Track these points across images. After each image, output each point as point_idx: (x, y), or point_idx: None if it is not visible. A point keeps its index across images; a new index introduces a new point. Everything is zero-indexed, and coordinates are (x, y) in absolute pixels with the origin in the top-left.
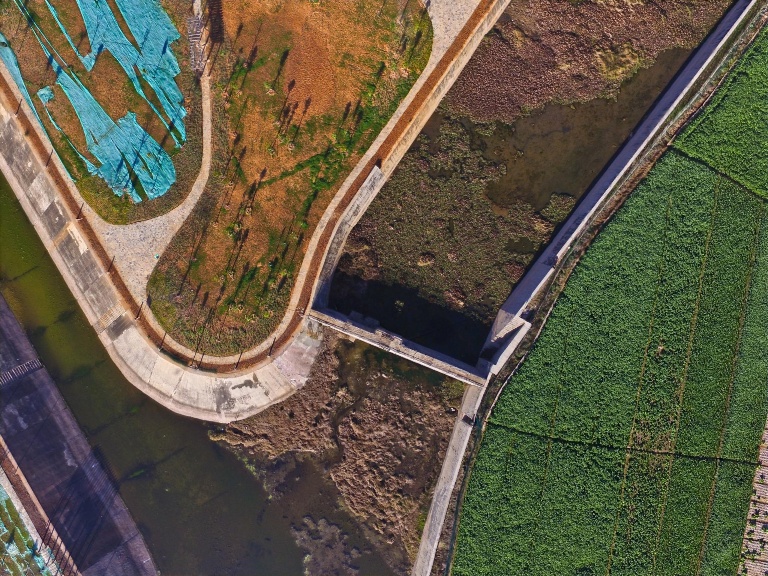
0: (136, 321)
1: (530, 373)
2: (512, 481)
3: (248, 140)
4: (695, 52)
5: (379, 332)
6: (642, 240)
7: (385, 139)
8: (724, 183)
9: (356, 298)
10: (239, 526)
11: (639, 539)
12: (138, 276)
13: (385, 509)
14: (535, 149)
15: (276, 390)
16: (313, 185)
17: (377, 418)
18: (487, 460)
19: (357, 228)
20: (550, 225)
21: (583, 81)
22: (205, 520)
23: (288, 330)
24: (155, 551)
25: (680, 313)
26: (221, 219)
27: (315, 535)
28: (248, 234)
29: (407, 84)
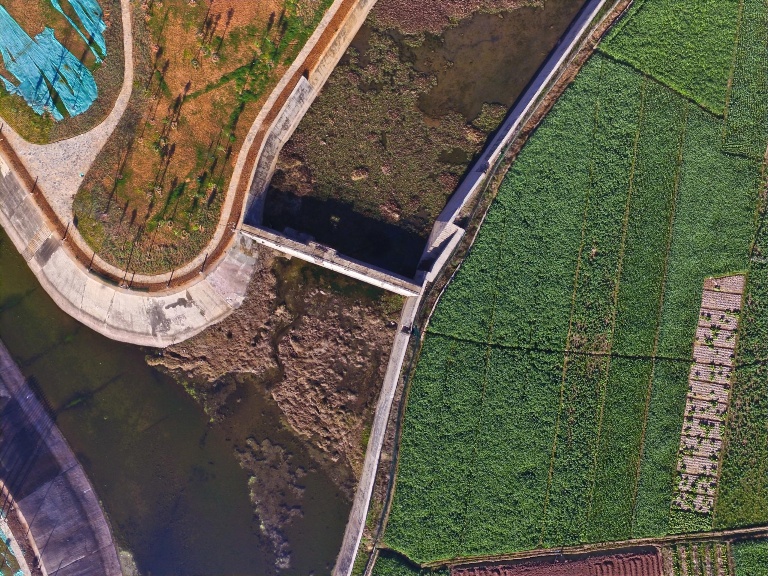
0: (63, 242)
1: (466, 280)
2: (452, 389)
3: (171, 53)
4: None
5: (312, 244)
6: (571, 143)
7: (311, 49)
8: (650, 84)
9: (291, 215)
10: (181, 451)
11: (579, 440)
12: (63, 196)
13: (328, 426)
14: (465, 59)
15: (212, 310)
16: (239, 97)
17: (317, 335)
18: (426, 369)
19: (289, 144)
20: (482, 135)
21: None
22: (146, 447)
23: (220, 246)
24: (96, 481)
25: (611, 215)
26: (146, 135)
27: (259, 456)
28: (175, 149)
29: None
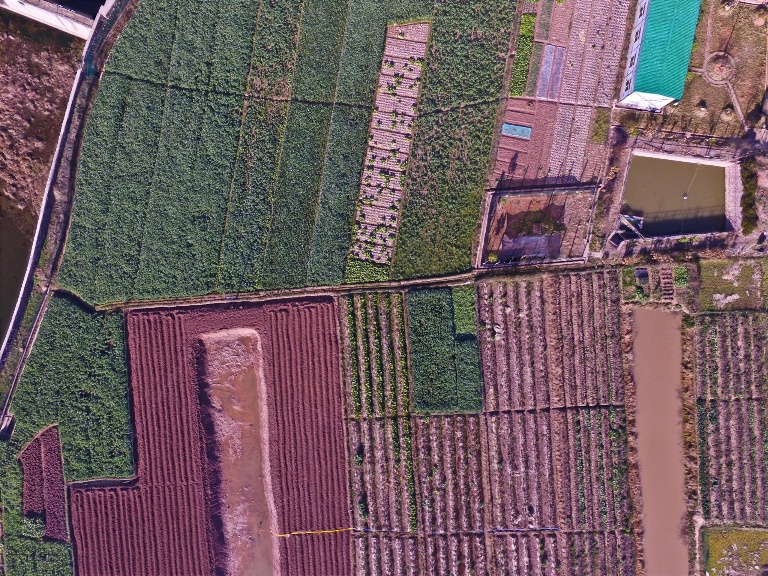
0: None
1: (143, 18)
2: (127, 128)
3: None
4: None
5: None
6: None
7: None
8: None
9: None
10: None
11: (256, 185)
12: None
13: (14, 173)
14: None
15: None
16: None
17: (4, 80)
18: (101, 107)
19: None
20: None
21: None
22: None
23: None
24: None
25: None
26: None
27: None
28: None
29: None
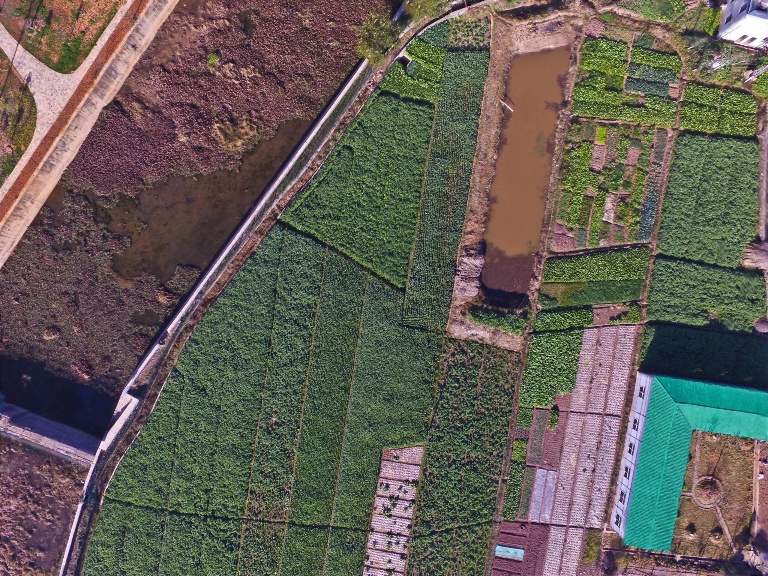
0: None
1: (143, 447)
2: (128, 554)
3: None
4: (315, 123)
5: None
6: (250, 314)
7: None
8: (331, 256)
9: None
10: None
11: None
12: None
13: None
14: (159, 221)
15: None
16: None
17: (6, 492)
18: (102, 535)
19: None
20: (174, 297)
21: (204, 153)
22: None
23: None
24: None
25: (290, 385)
26: None
27: None
28: None
29: (11, 161)
